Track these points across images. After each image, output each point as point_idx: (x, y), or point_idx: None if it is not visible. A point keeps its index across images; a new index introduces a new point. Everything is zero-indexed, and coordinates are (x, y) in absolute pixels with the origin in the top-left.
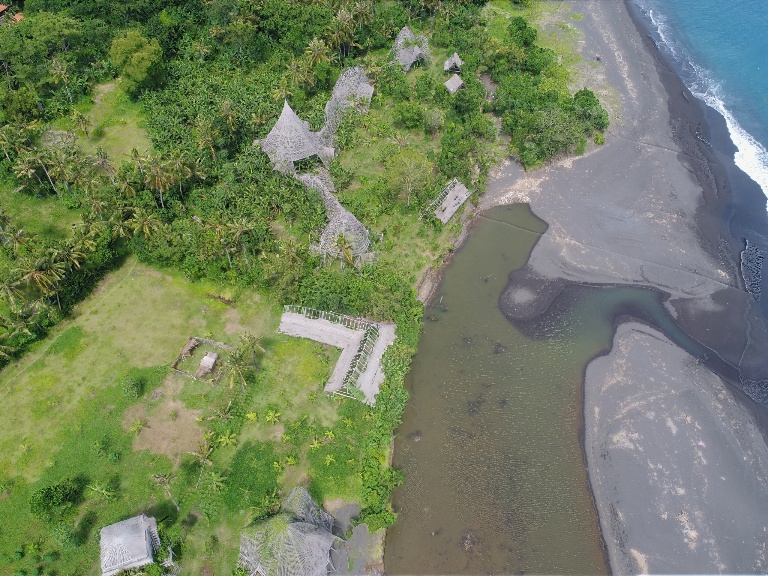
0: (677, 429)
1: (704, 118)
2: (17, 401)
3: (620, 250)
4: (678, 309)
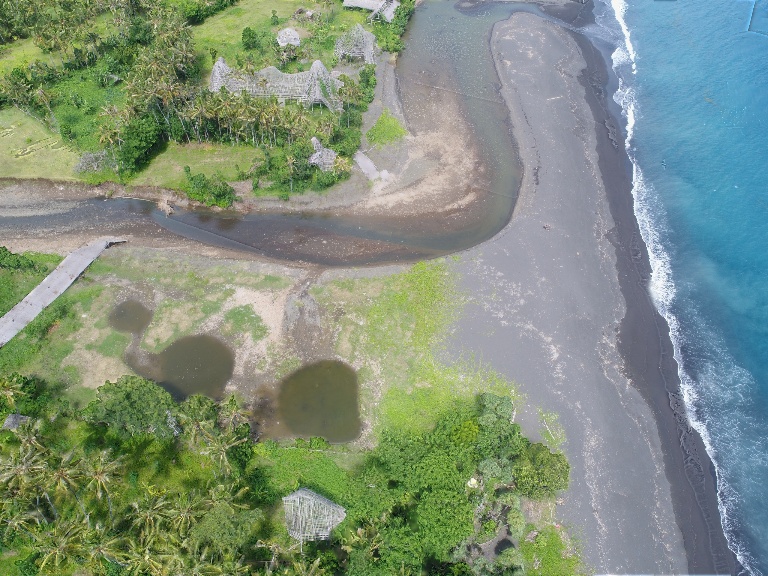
0: (534, 35)
1: None
2: (218, 26)
3: None
4: (546, 8)
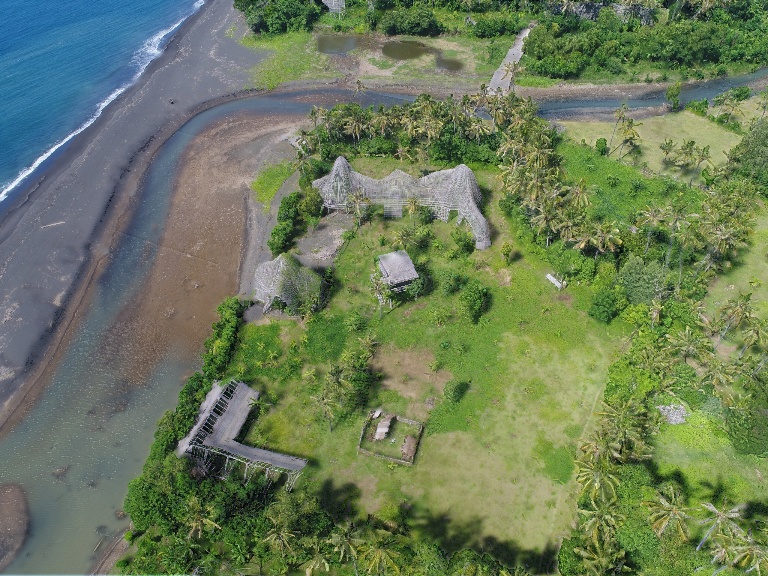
0: None
1: None
2: (567, 395)
3: None
4: None
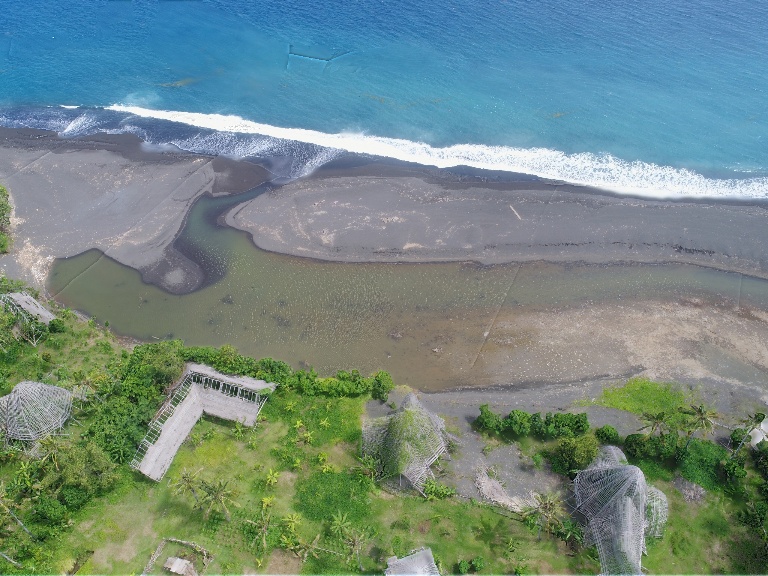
0: (323, 211)
1: (14, 128)
2: None
3: (149, 208)
4: (222, 190)
